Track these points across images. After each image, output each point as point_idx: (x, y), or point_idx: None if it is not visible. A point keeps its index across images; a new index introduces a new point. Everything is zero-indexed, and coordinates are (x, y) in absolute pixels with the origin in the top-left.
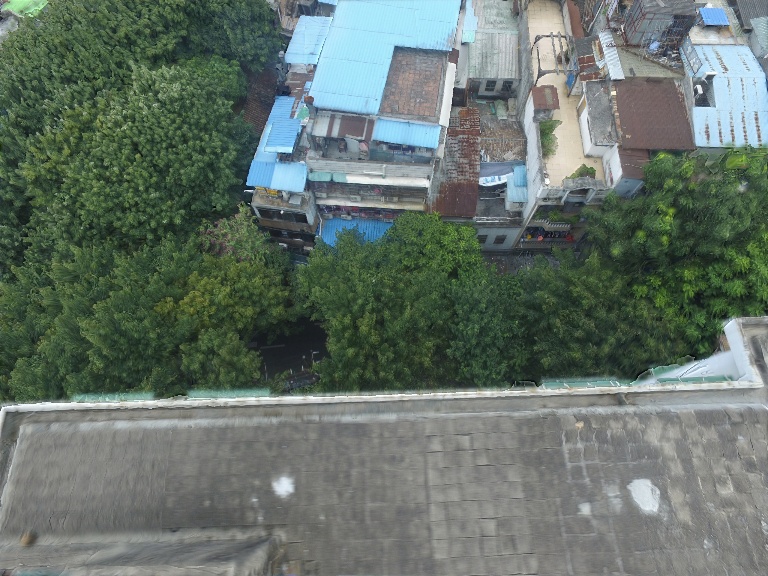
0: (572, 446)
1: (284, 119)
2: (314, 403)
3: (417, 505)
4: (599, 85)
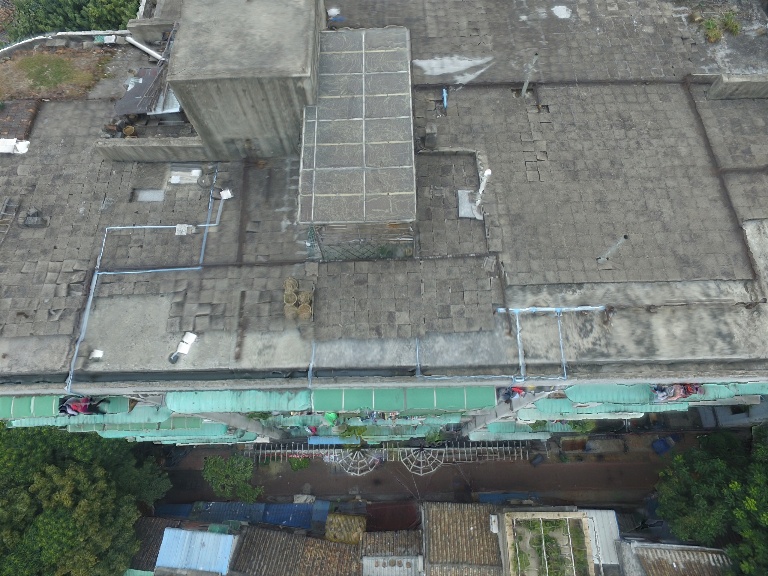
0: None
1: None
2: None
3: (418, 18)
4: None
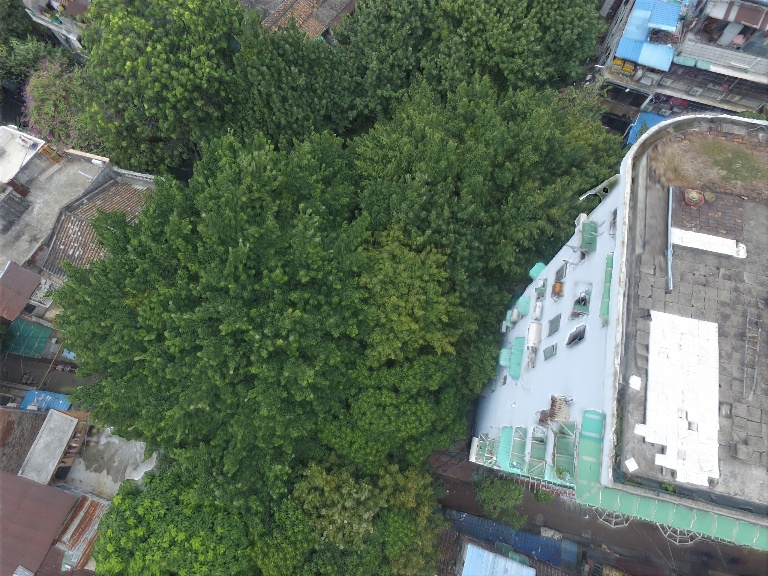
0: None
1: (665, 3)
2: None
3: None
4: None
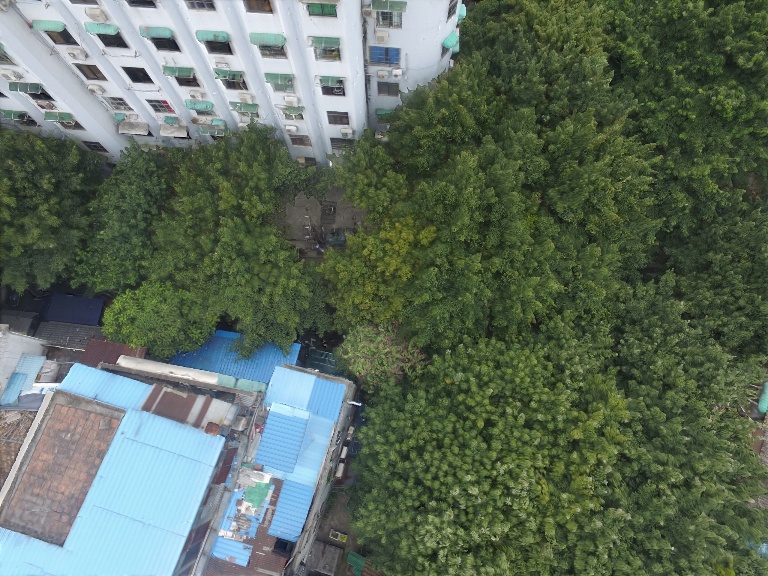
0: None
1: (279, 467)
2: None
3: None
4: None
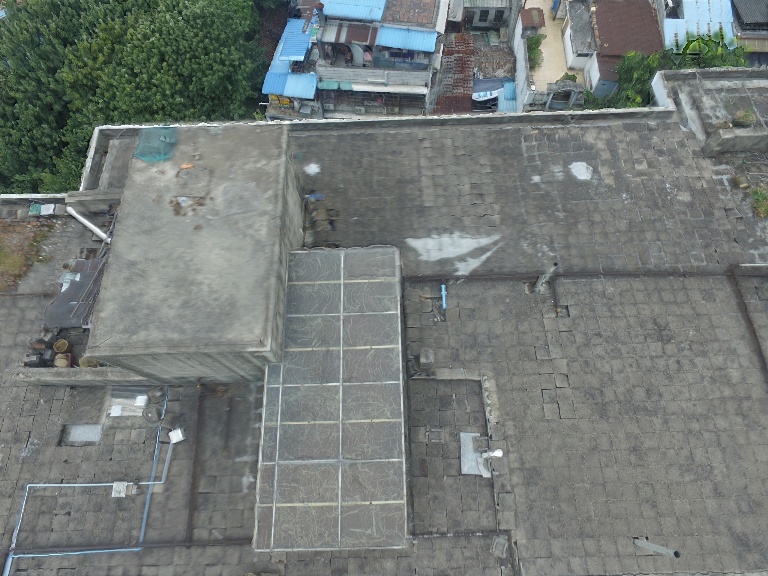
0: (529, 144)
1: (296, 34)
2: (334, 123)
3: (412, 178)
4: (581, 4)
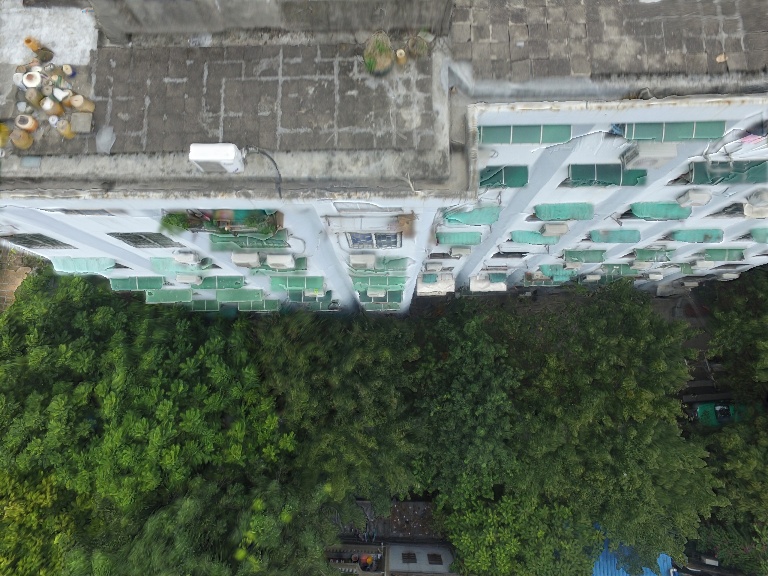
0: (733, 35)
1: None
2: None
3: None
4: None
